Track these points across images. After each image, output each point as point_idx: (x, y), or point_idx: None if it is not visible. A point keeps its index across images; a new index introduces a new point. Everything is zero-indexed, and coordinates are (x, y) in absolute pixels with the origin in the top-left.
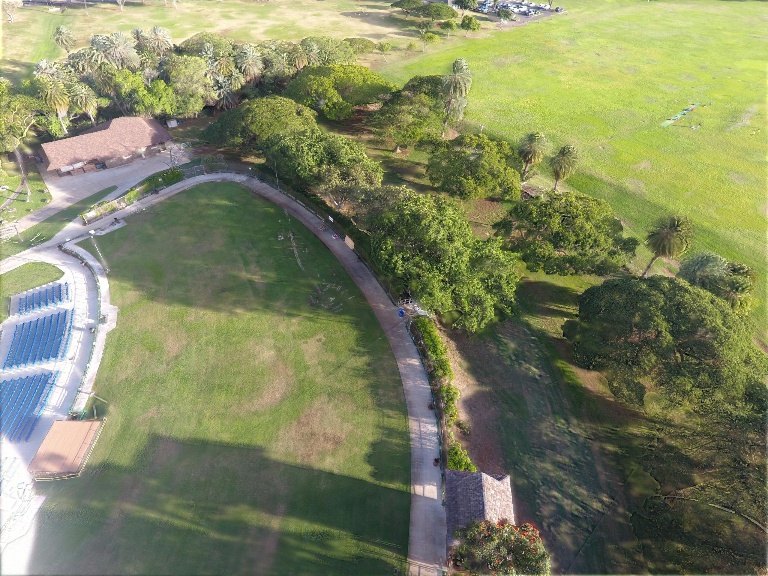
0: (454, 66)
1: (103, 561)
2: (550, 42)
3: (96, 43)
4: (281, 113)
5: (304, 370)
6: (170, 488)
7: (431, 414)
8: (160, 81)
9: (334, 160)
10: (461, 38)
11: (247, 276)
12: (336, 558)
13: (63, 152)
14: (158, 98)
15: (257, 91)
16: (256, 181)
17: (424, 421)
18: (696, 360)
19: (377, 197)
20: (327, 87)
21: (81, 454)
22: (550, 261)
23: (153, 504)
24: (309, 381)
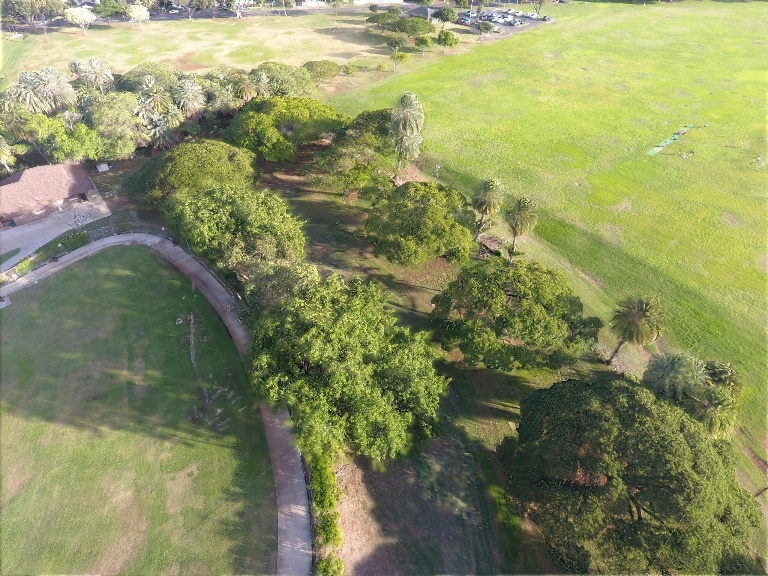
0: (402, 101)
1: None
2: (534, 56)
3: (23, 81)
4: (206, 160)
5: (161, 523)
6: None
7: None
8: (80, 125)
9: (243, 227)
10: (438, 54)
11: (127, 376)
12: None
13: None
14: (80, 143)
15: (198, 128)
16: (169, 244)
17: None
18: (656, 521)
19: (269, 288)
20: (266, 126)
21: None
22: (490, 354)
23: None
24: (163, 541)
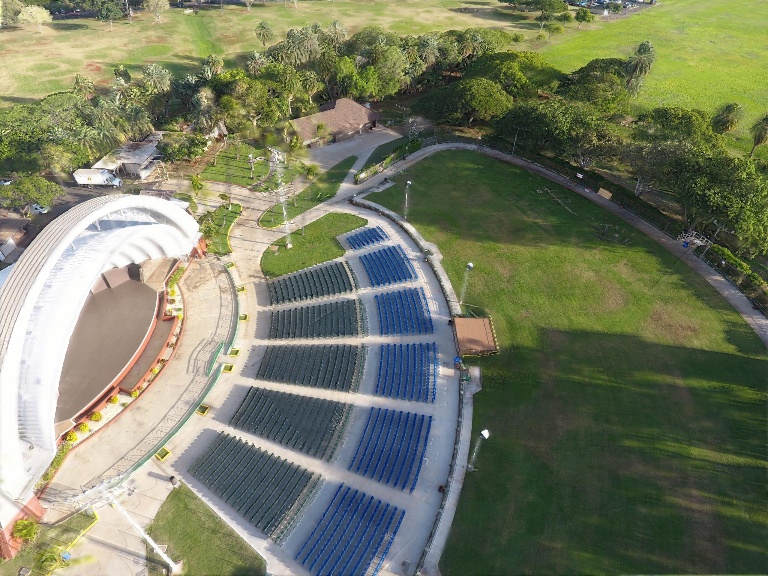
0: (642, 48)
1: (558, 405)
2: (661, 32)
3: (293, 36)
4: (491, 92)
5: (628, 285)
6: (578, 360)
7: (758, 313)
8: (370, 67)
9: (580, 126)
10: (575, 30)
11: (530, 220)
12: (745, 401)
13: (306, 127)
14: (365, 82)
15: None
16: (487, 149)
17: (756, 317)
18: None
19: (660, 149)
20: (515, 70)
21: (491, 339)
22: None
23: (572, 370)
24: (638, 292)
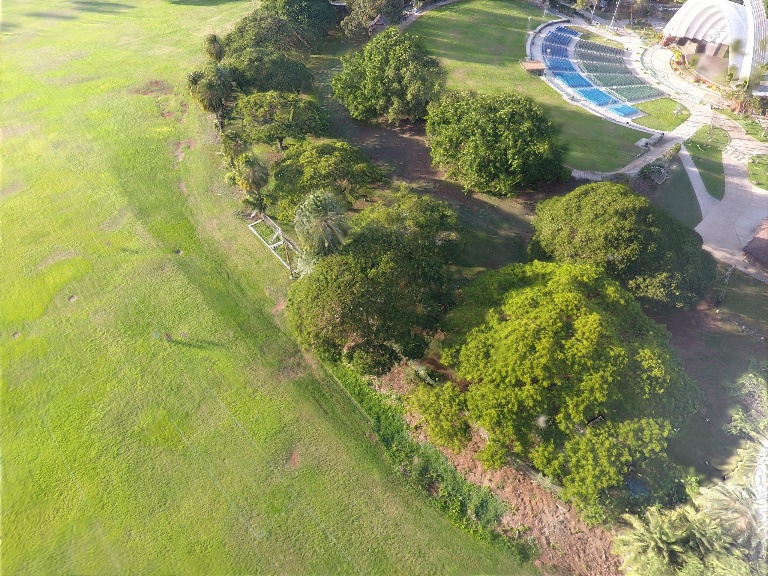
0: None
1: (493, 52)
2: None
3: None
4: None
5: (448, 77)
6: None
7: None
8: None
9: None
10: None
11: None
12: None
13: None
14: None
15: None
16: None
17: None
18: None
19: None
20: None
21: None
22: None
23: None
24: None
